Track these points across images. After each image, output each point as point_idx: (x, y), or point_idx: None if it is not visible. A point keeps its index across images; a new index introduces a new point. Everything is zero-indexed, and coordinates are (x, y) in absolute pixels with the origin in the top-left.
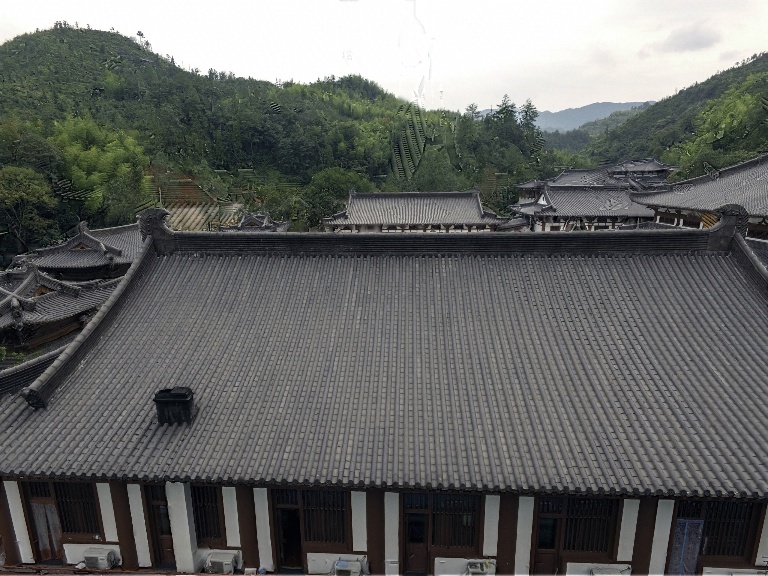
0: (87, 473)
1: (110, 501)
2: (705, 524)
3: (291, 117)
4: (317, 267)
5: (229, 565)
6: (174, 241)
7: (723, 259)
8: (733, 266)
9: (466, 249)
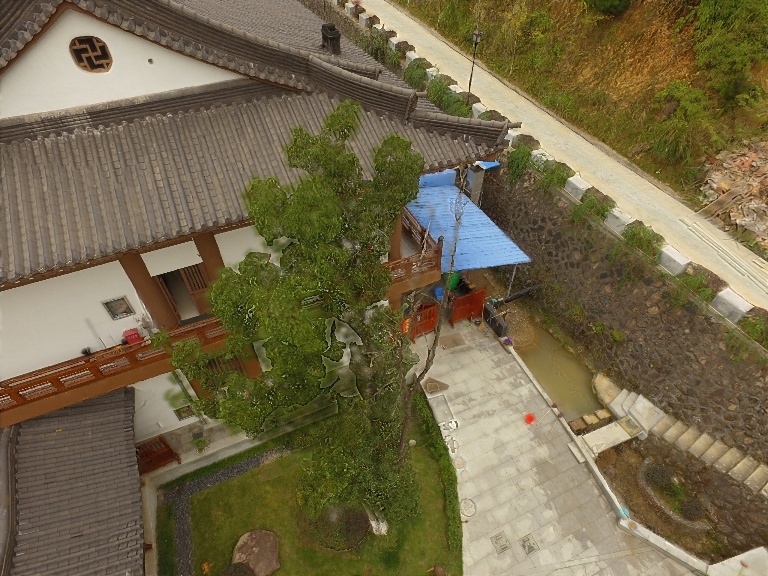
0: None
1: None
2: None
3: None
4: None
5: None
6: None
7: None
8: None
9: None
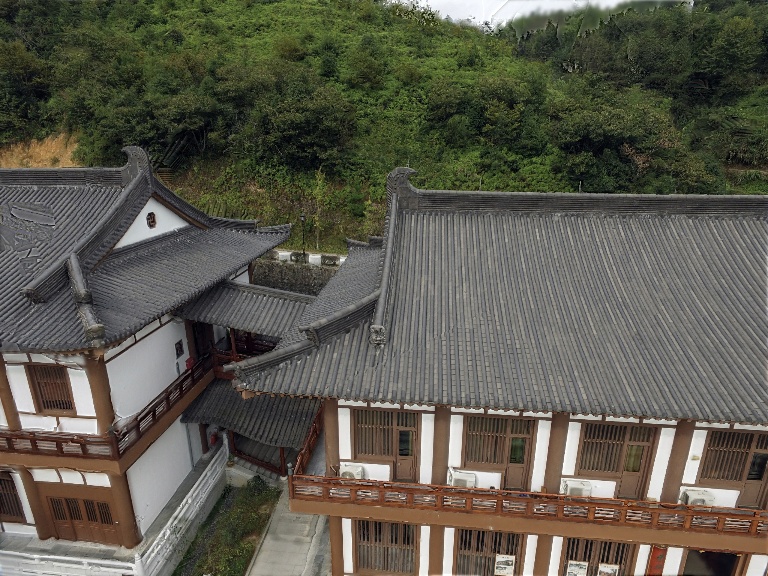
0: None
1: None
2: None
3: None
4: None
5: None
6: None
7: None
8: None
9: None
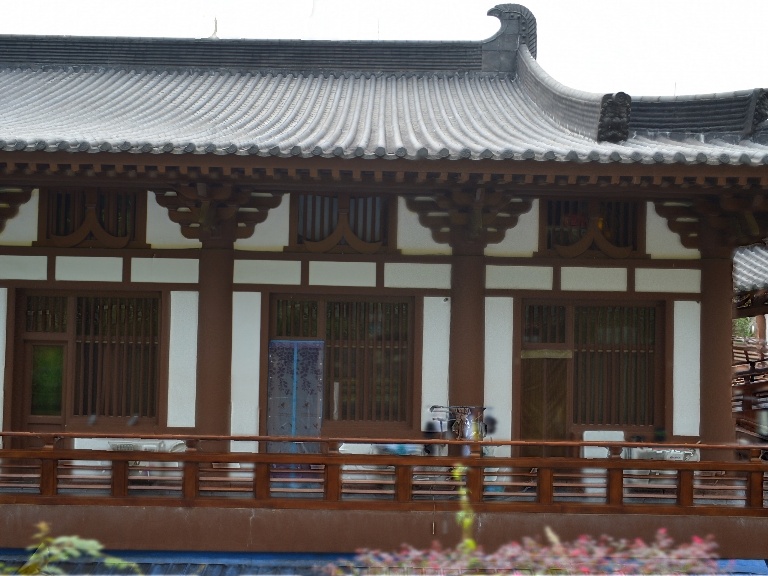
0: None
1: None
2: (330, 352)
3: None
4: None
5: None
6: None
7: (505, 82)
8: (515, 87)
9: (113, 60)
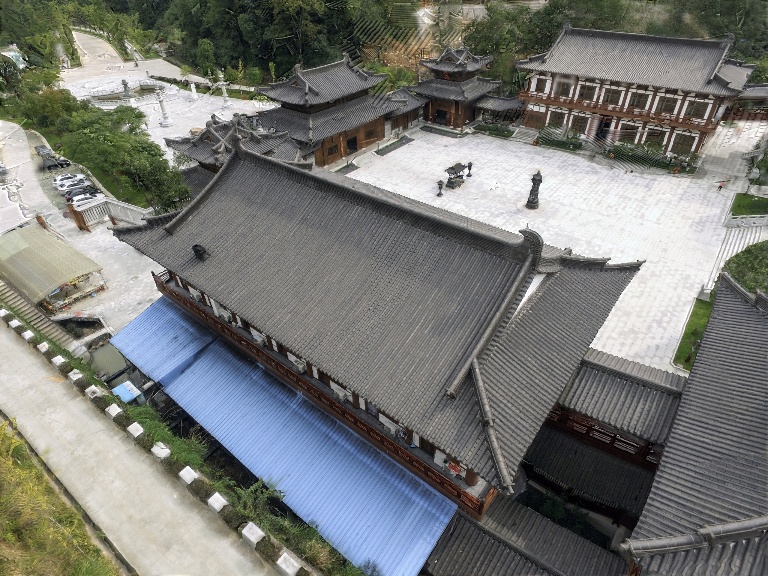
0: (169, 268)
1: None
2: None
3: None
4: (297, 191)
5: (226, 318)
6: (244, 154)
7: (517, 268)
8: None
9: (368, 205)
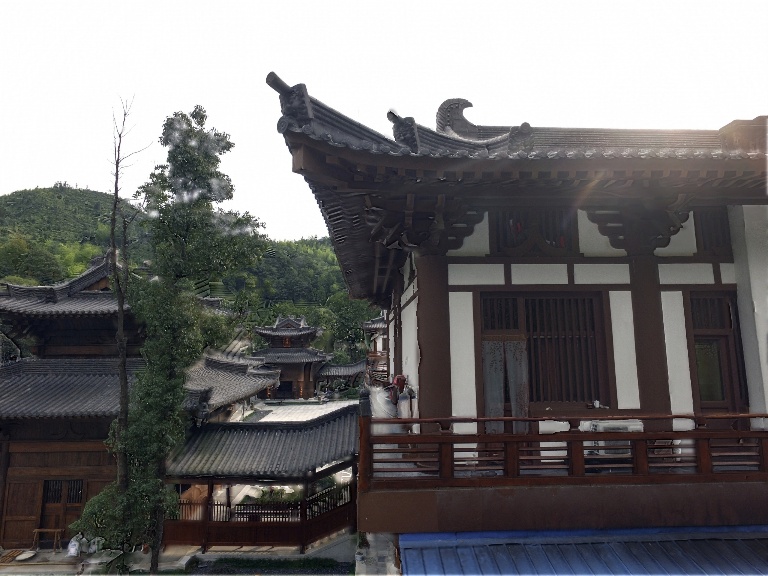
0: None
1: (630, 325)
2: None
3: (285, 261)
4: None
5: None
6: (477, 134)
7: None
8: None
9: None
